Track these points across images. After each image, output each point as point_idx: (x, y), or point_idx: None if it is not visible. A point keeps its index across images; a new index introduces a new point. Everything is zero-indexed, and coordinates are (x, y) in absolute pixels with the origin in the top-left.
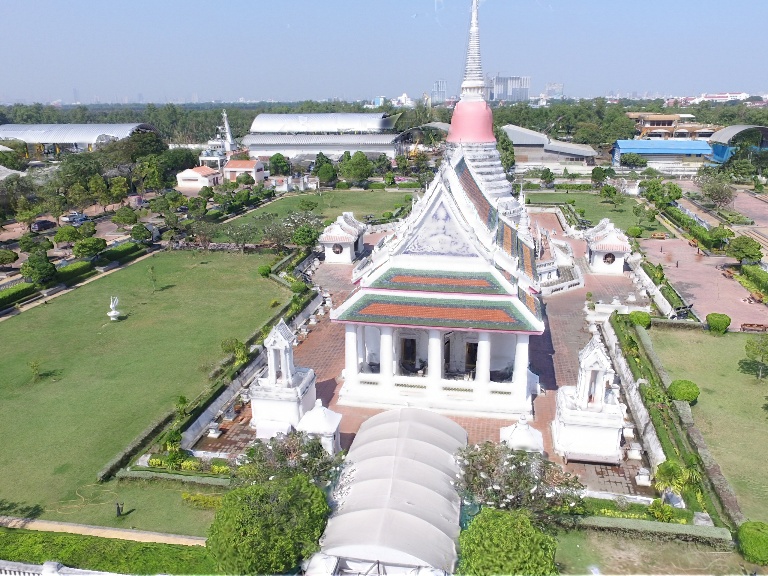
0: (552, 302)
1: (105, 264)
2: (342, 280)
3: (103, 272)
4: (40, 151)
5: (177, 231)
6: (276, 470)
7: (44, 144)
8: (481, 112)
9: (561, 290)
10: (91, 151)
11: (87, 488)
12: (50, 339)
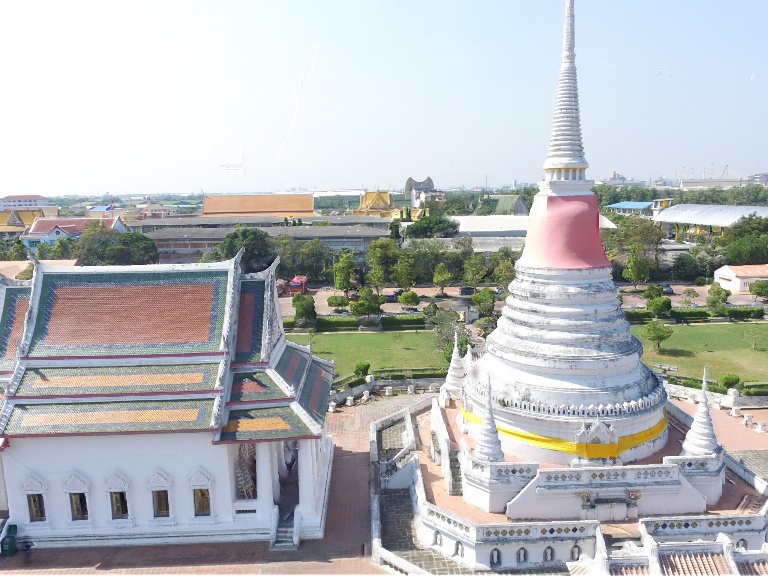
0: (339, 567)
1: (369, 325)
2: (398, 409)
3: (360, 331)
4: (684, 231)
5: None
6: None
7: (688, 224)
8: (540, 213)
9: (405, 575)
10: (615, 234)
11: None
12: None
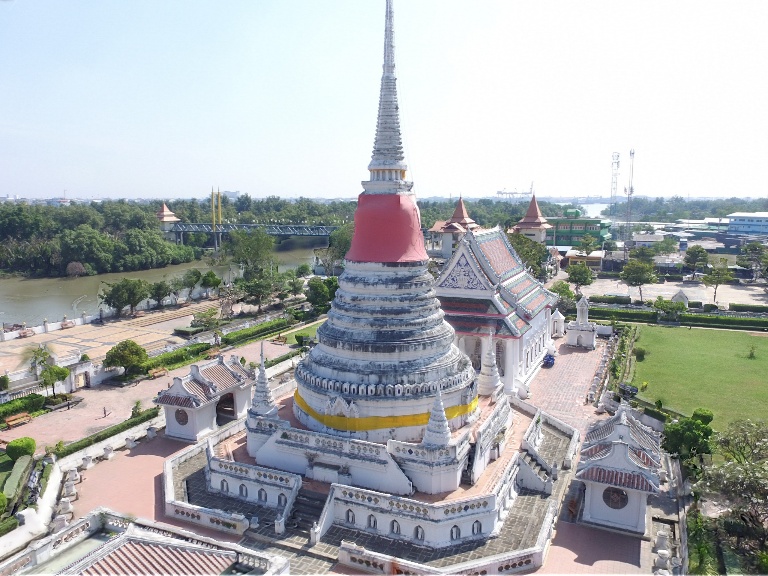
0: None
1: None
2: None
3: None
4: None
5: None
6: None
7: None
8: None
9: None
10: None
11: (642, 328)
12: None
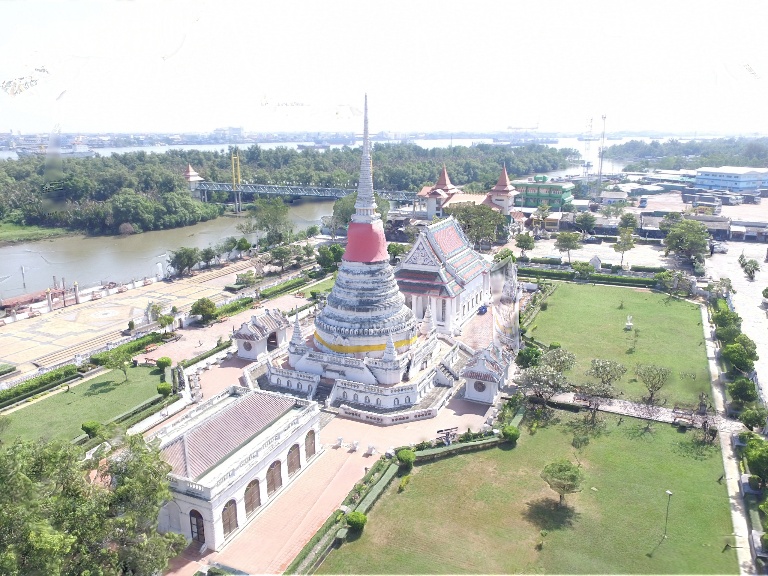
0: None
1: None
2: None
3: None
4: None
5: None
6: None
7: None
8: None
9: None
10: None
11: None
12: (650, 322)
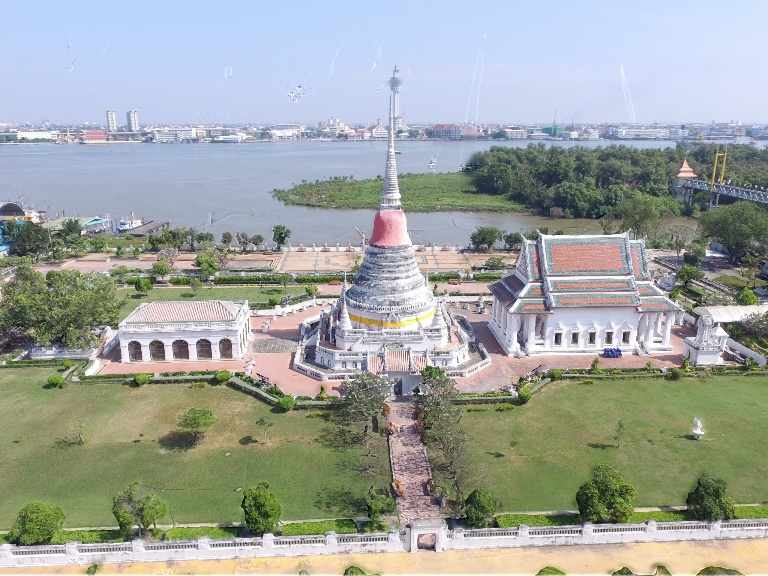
0: (477, 320)
1: None
2: (481, 380)
3: None
4: None
5: (358, 530)
6: (767, 321)
7: None
8: None
9: None
10: None
11: None
12: (764, 452)
